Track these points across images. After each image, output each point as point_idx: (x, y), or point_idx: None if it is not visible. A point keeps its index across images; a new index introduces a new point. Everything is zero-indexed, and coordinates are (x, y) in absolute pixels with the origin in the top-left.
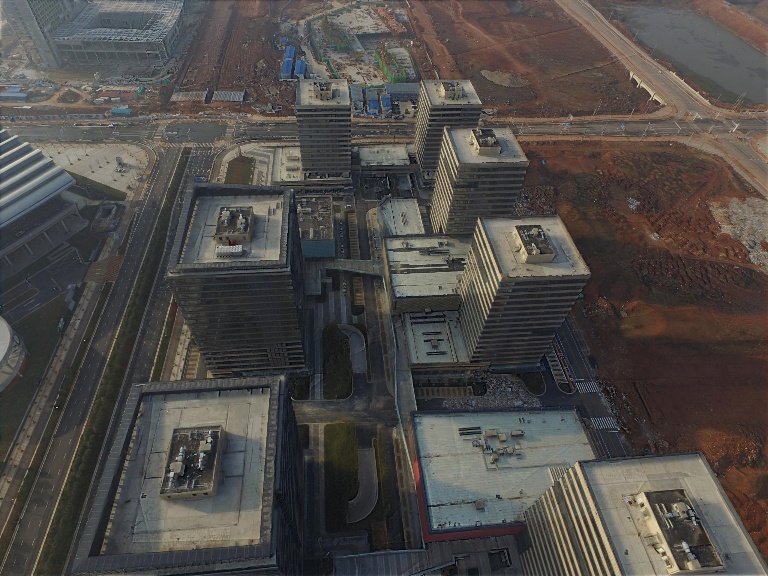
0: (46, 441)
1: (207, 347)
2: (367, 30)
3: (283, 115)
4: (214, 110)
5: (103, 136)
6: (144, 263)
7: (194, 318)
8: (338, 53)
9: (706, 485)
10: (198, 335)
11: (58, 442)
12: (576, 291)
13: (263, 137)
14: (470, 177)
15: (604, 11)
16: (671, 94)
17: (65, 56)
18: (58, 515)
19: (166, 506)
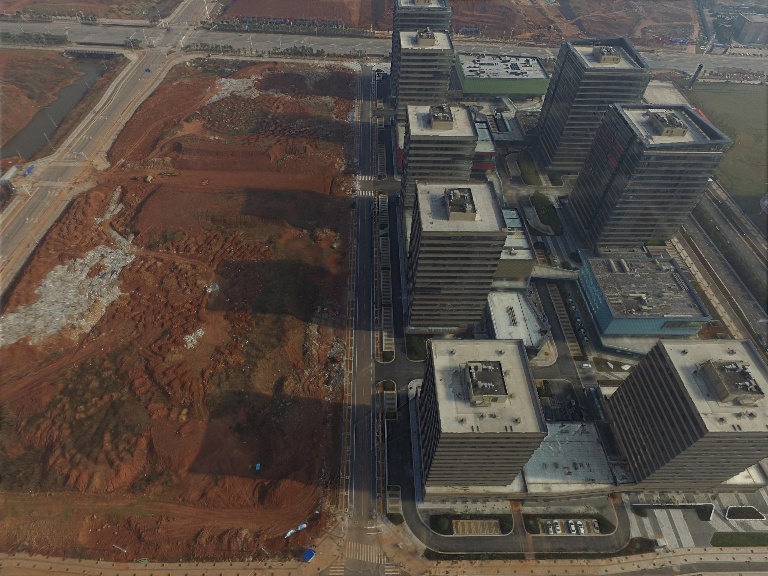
0: None
1: None
2: None
3: None
4: None
5: None
6: None
7: None
8: None
9: None
10: None
11: None
12: None
13: None
14: None
15: None
16: None
17: None
18: None
19: None
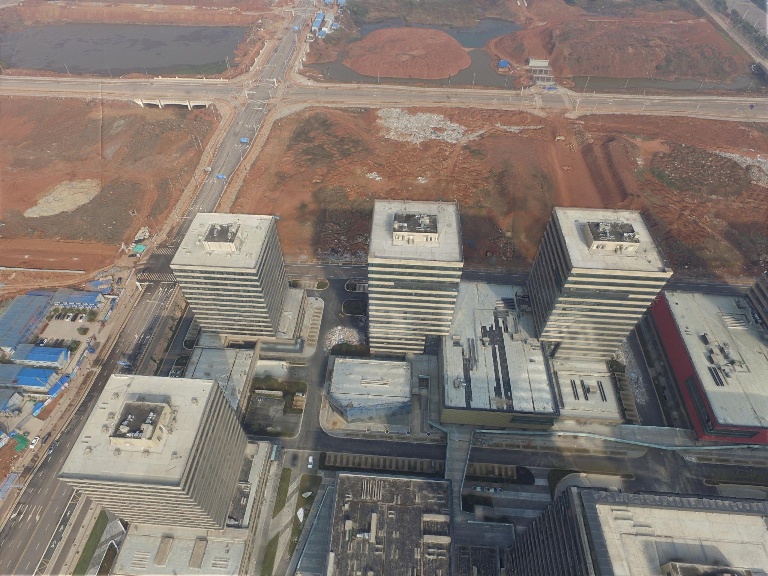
0: None
1: None
2: None
3: None
4: None
5: None
6: None
7: None
8: None
9: None
10: None
11: None
12: None
13: None
14: None
15: None
16: (195, 93)
17: None
18: None
19: None
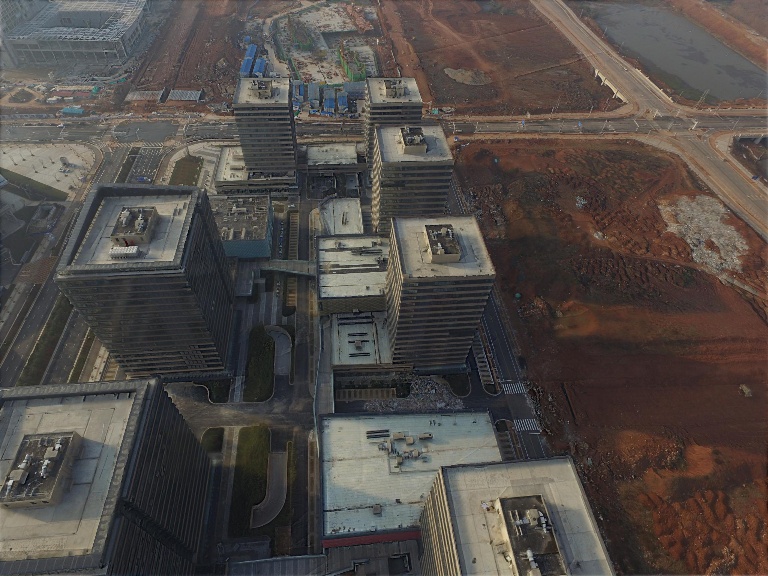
0: None
1: (117, 350)
2: (333, 28)
3: None
4: (168, 109)
5: (51, 136)
6: None
7: (95, 320)
8: (301, 52)
9: (570, 491)
10: (104, 337)
11: None
12: (485, 291)
13: (214, 136)
14: (396, 176)
15: (577, 8)
16: (634, 92)
17: (22, 55)
18: None
19: (5, 515)
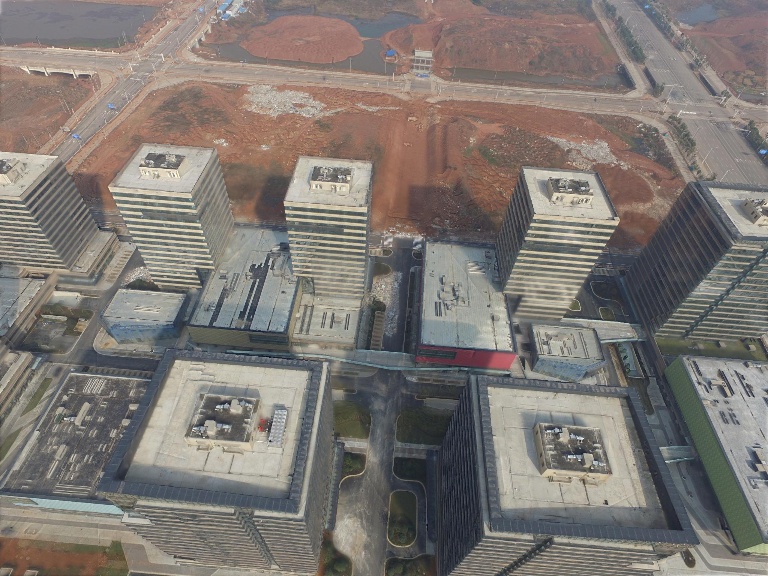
0: None
1: (317, 547)
2: None
3: None
4: None
5: None
6: None
7: None
8: None
9: (540, 173)
10: None
11: None
12: None
13: None
14: (200, 198)
15: None
16: (83, 63)
17: None
18: None
19: (611, 479)
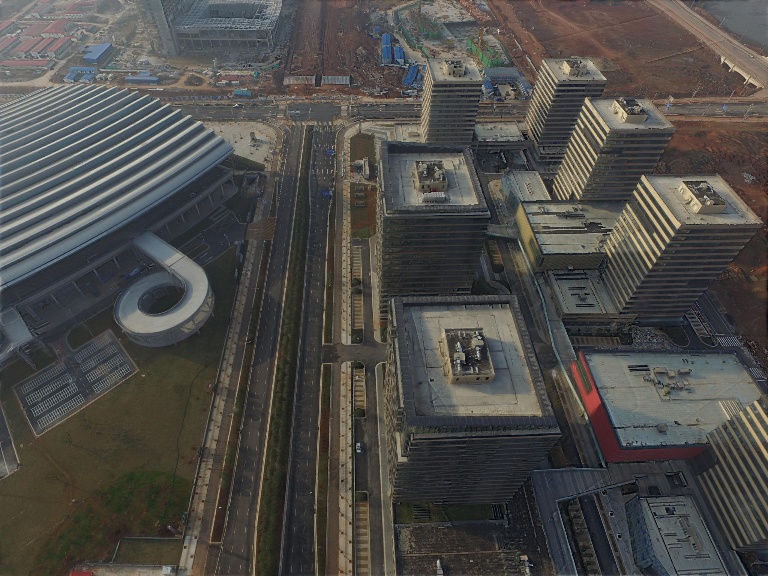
0: (247, 369)
1: (389, 289)
2: (453, 19)
3: (391, 97)
4: (326, 92)
5: (232, 115)
6: (297, 224)
7: (390, 259)
8: (430, 40)
9: None
10: (386, 277)
11: (257, 370)
12: (744, 241)
13: (376, 116)
14: (617, 143)
15: None
16: (767, 77)
17: (183, 44)
18: (276, 426)
19: (453, 388)
